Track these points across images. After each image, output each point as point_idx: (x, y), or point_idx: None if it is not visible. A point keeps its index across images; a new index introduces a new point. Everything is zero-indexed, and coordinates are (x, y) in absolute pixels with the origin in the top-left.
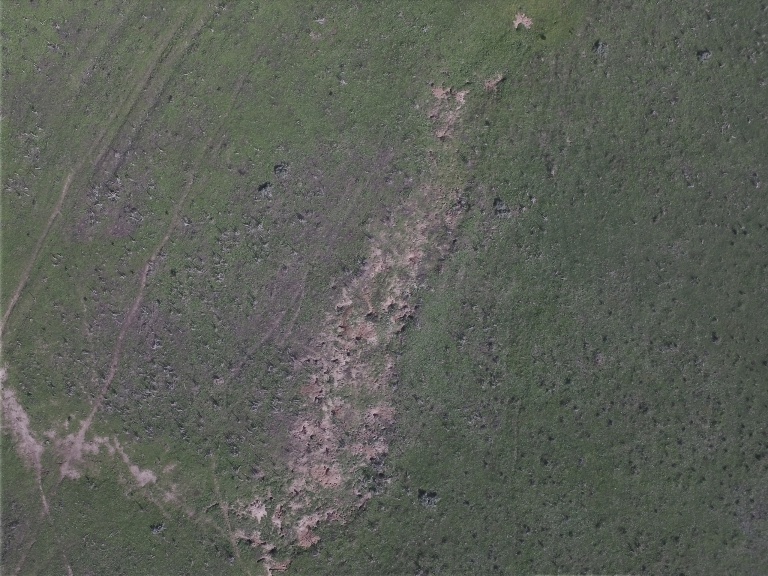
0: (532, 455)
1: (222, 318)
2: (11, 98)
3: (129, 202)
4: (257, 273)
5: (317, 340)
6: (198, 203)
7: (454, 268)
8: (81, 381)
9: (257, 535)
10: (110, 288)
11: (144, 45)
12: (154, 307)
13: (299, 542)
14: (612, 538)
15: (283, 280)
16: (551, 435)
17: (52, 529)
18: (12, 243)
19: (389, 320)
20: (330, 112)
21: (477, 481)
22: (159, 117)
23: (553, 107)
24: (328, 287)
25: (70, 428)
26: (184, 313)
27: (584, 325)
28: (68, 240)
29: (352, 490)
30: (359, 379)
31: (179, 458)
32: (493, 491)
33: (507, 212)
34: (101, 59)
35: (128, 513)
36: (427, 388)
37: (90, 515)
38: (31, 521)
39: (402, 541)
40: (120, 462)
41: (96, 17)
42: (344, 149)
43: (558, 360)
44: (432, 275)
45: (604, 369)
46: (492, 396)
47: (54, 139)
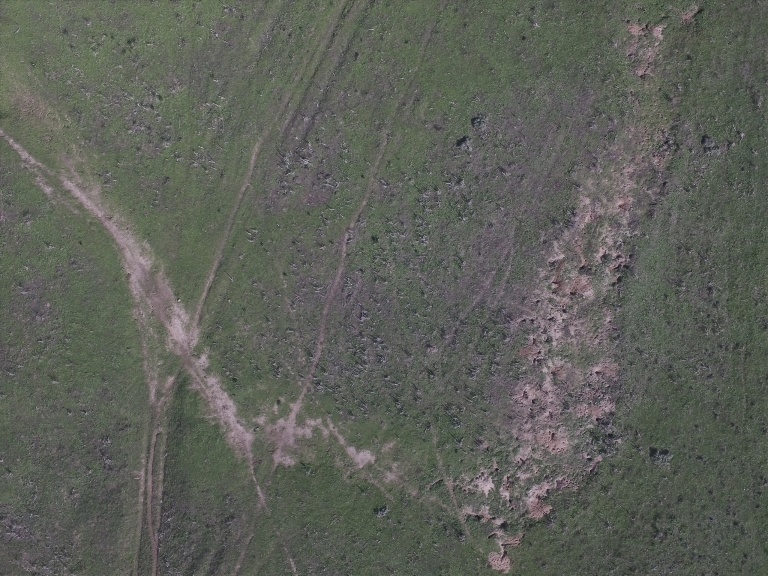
0: (762, 402)
1: (430, 283)
2: (189, 68)
3: (322, 168)
4: (462, 233)
5: (531, 298)
6: (394, 164)
7: (667, 212)
8: (287, 361)
9: (485, 510)
10: (310, 261)
11: (324, 2)
12: (357, 277)
13: (530, 513)
14: None
15: (490, 238)
16: None
17: (270, 521)
18: (202, 221)
19: (604, 272)
20: (525, 58)
21: (708, 434)
22: (346, 76)
23: (755, 36)
24: (538, 242)
25: (280, 412)
26: (389, 281)
27: None
28: (261, 213)
29: (581, 454)
30: (578, 336)
31: (398, 435)
32: (725, 443)
33: (717, 149)
34: (280, 20)
35: (349, 497)
36: (650, 340)
37: (309, 503)
38: (247, 514)
39: (637, 503)
40: (335, 444)
41: None
42: (543, 95)
43: None
44: (645, 221)
45: None
46: (716, 343)
47: (238, 108)
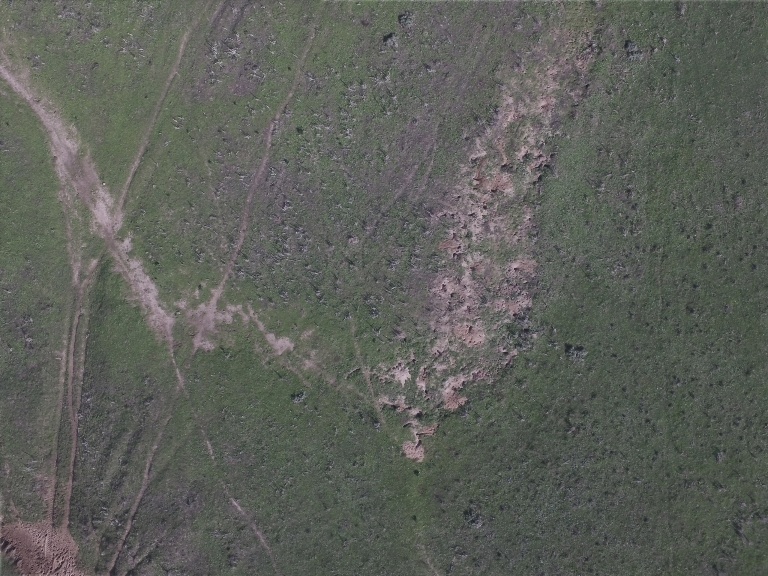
0: (677, 304)
1: (353, 176)
2: None
3: (249, 59)
4: (386, 127)
5: (453, 194)
6: (321, 57)
7: (588, 114)
8: (210, 248)
9: (401, 399)
10: (235, 149)
11: None
12: (281, 167)
13: (445, 404)
14: (763, 385)
15: (414, 134)
16: (695, 283)
17: (188, 403)
18: (129, 107)
19: (525, 170)
20: None
21: (623, 333)
22: None
23: None
24: (461, 138)
25: (201, 297)
26: (313, 172)
27: (722, 168)
28: (188, 101)
29: (497, 348)
30: (498, 232)
31: (317, 323)
32: (640, 342)
33: (639, 53)
34: None
35: (267, 382)
36: (568, 238)
37: (227, 387)
38: (166, 396)
39: (551, 398)
40: (255, 330)
41: None
42: None
43: (698, 205)
44: (566, 122)
45: (745, 212)
46: (634, 245)
47: None
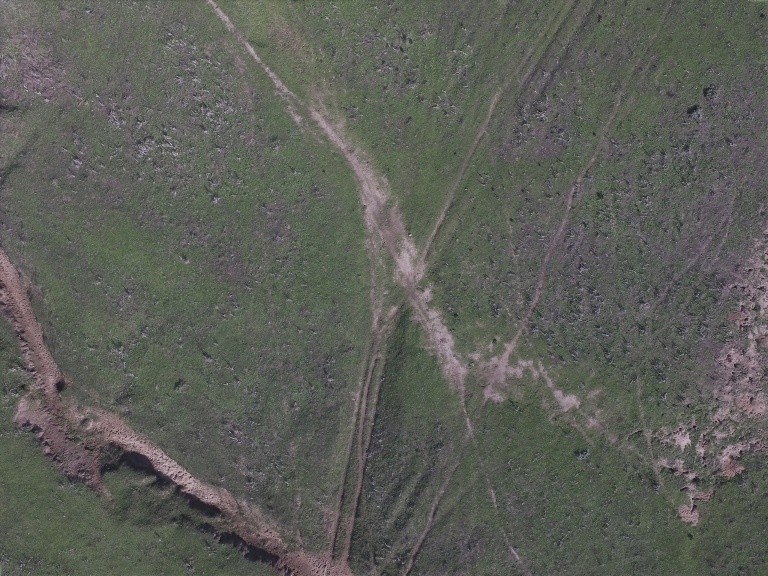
0: None
1: (648, 242)
2: (439, 15)
3: (556, 123)
4: (684, 197)
5: (744, 267)
6: (625, 125)
7: None
8: (506, 303)
9: (680, 464)
10: (536, 209)
11: None
12: (580, 230)
13: (722, 472)
14: None
15: (710, 205)
16: None
17: (476, 452)
18: (439, 162)
19: None
20: (761, 34)
21: None
22: (588, 36)
23: None
24: (756, 213)
25: (494, 351)
26: (610, 236)
27: None
28: (494, 160)
29: None
30: None
31: (604, 383)
32: None
33: None
34: None
35: (553, 438)
36: None
37: (515, 439)
38: (455, 444)
39: None
40: (544, 386)
41: None
42: None
43: None
44: None
45: None
46: None
47: (482, 57)
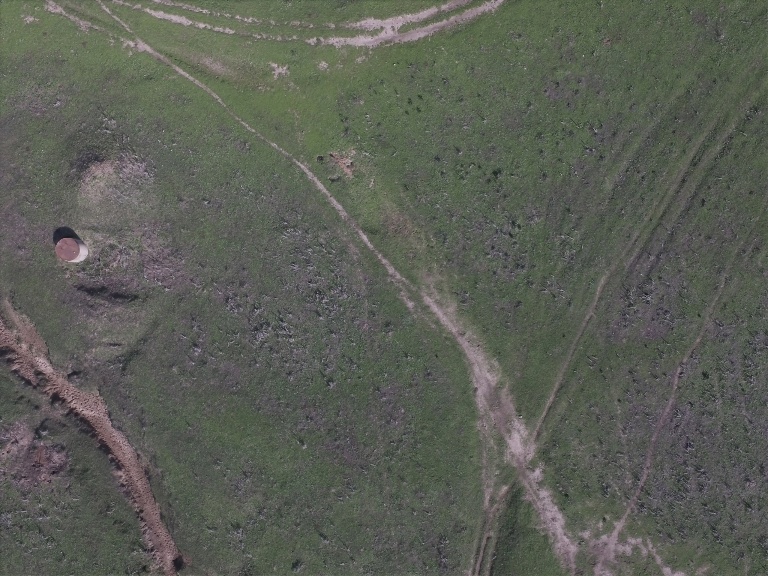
0: None
1: (753, 421)
2: (547, 200)
3: (662, 305)
4: None
5: None
6: (729, 306)
7: None
8: (615, 483)
9: None
10: (643, 390)
11: (677, 149)
12: (686, 409)
13: None
14: None
15: None
16: None
17: None
18: (548, 344)
19: None
20: None
21: None
22: (692, 220)
23: None
24: None
25: (604, 529)
26: (716, 416)
27: None
28: (602, 342)
29: None
30: None
31: (712, 561)
32: None
33: None
34: (635, 162)
35: None
36: None
37: None
38: None
39: None
40: (652, 564)
41: (631, 121)
42: None
43: None
44: None
45: None
46: None
47: (589, 241)
